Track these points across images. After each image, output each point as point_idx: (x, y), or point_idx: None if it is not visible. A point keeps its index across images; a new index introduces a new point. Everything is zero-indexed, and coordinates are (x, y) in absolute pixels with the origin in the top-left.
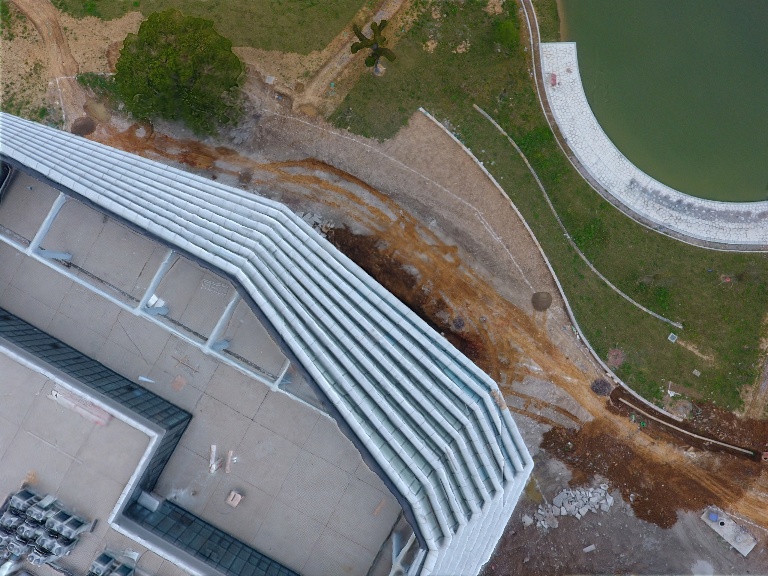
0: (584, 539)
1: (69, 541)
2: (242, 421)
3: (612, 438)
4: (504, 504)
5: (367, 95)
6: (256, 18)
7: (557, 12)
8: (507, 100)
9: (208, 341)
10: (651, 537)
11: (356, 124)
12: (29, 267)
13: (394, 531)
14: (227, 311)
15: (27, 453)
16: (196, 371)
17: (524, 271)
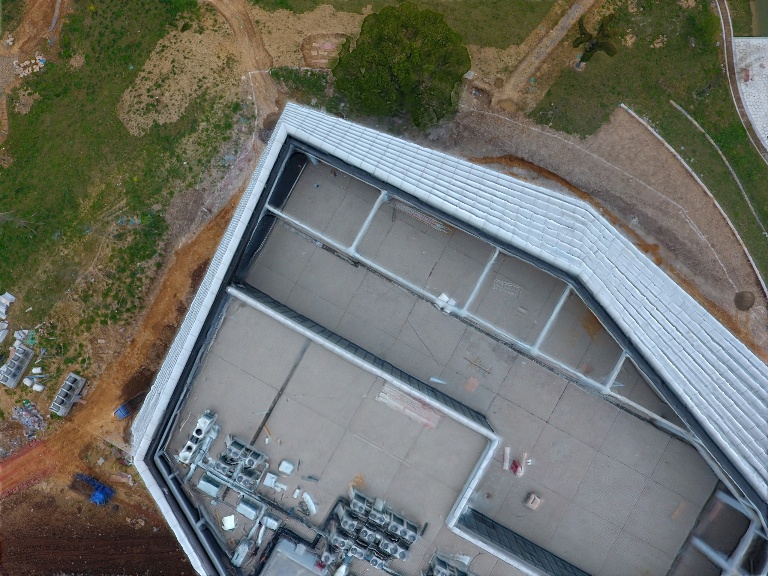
0: None
1: None
2: (536, 423)
3: None
4: None
5: (568, 90)
6: (449, 11)
7: (749, 6)
8: (703, 96)
9: (537, 343)
10: None
11: (558, 120)
12: (316, 266)
13: (693, 534)
14: (556, 313)
15: (354, 456)
16: (488, 372)
17: (728, 270)
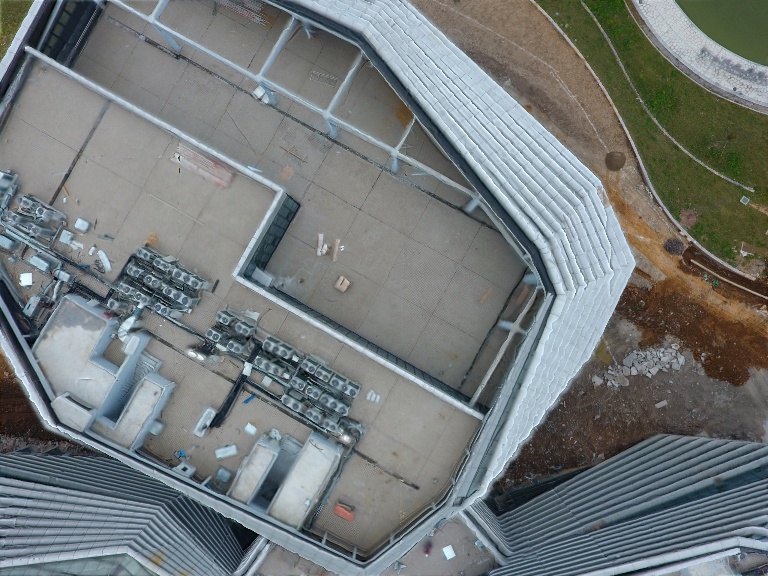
0: (656, 396)
1: (195, 293)
2: (349, 210)
3: (684, 297)
4: (611, 292)
5: None
6: None
7: None
8: None
9: (329, 107)
10: (723, 394)
11: None
12: (139, 58)
13: (501, 318)
14: (348, 77)
15: (149, 215)
16: (304, 161)
17: (598, 130)
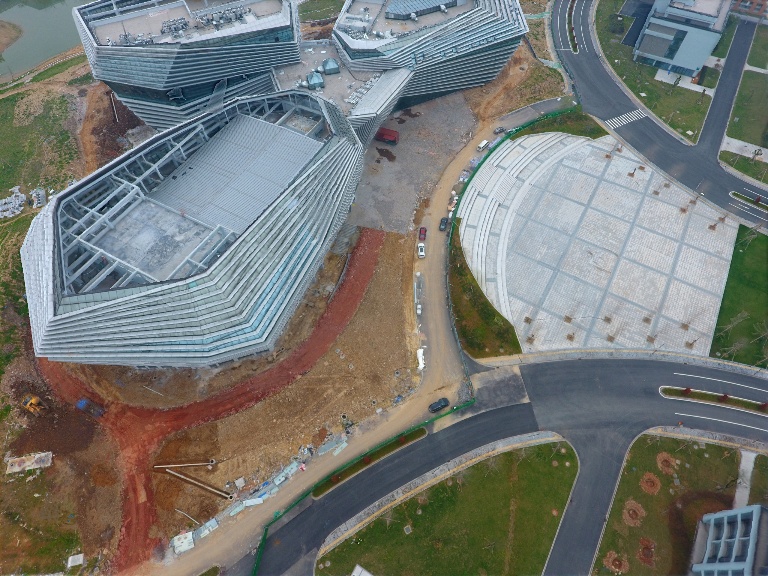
0: None
1: None
2: None
3: (331, 29)
4: None
5: None
6: None
7: None
8: None
9: None
10: None
11: None
12: None
13: None
14: None
15: (156, 25)
16: None
17: None
